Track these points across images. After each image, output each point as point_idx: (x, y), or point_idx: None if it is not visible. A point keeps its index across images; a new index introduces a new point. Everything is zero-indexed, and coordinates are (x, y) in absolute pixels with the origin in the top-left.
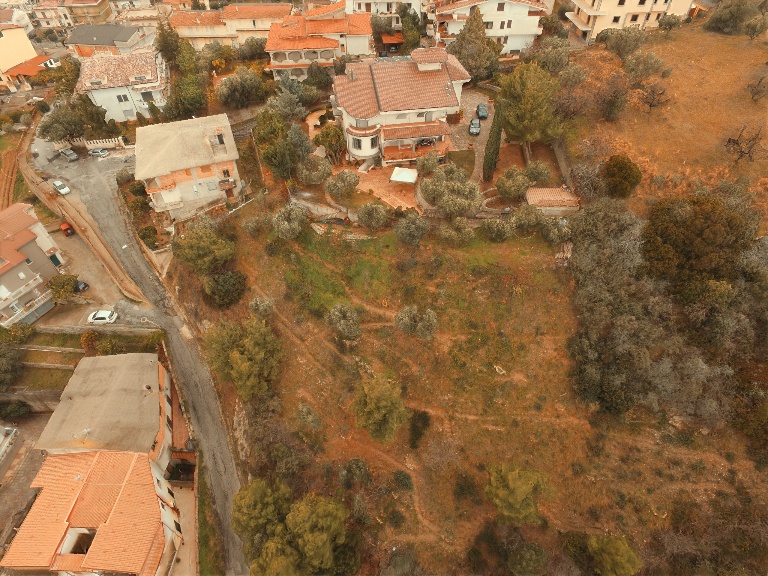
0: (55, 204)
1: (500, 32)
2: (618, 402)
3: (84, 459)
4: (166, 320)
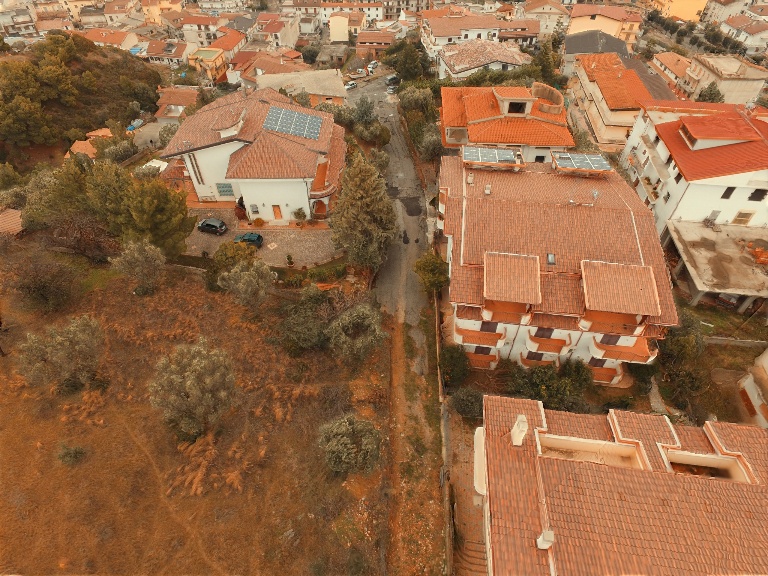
0: None
1: None
2: None
3: None
4: None
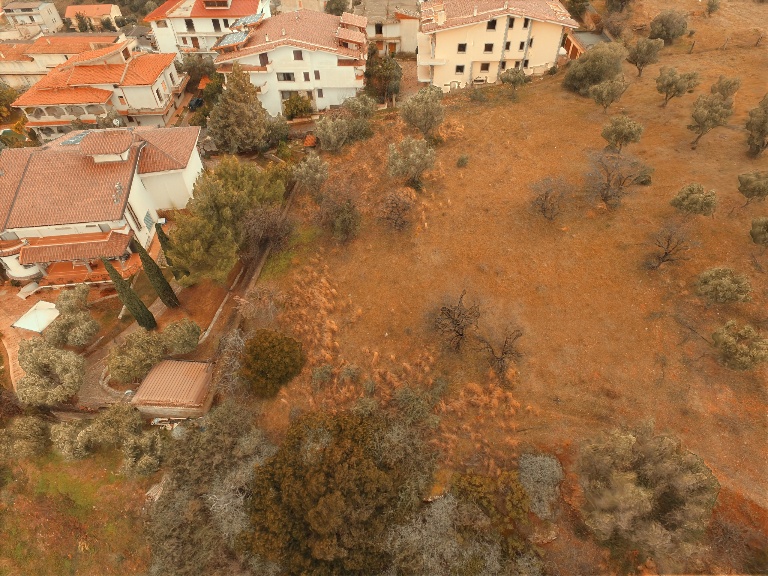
0: None
1: (306, 85)
2: None
3: None
4: None
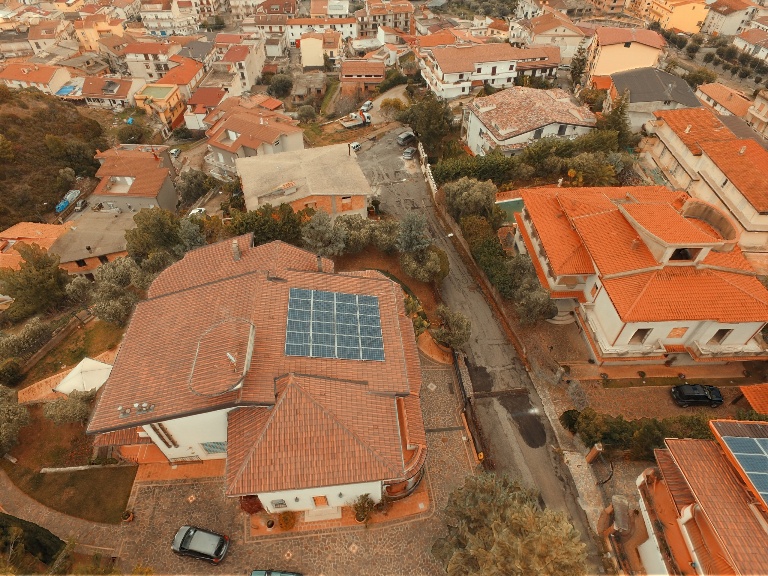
0: None
1: None
2: None
3: None
4: None
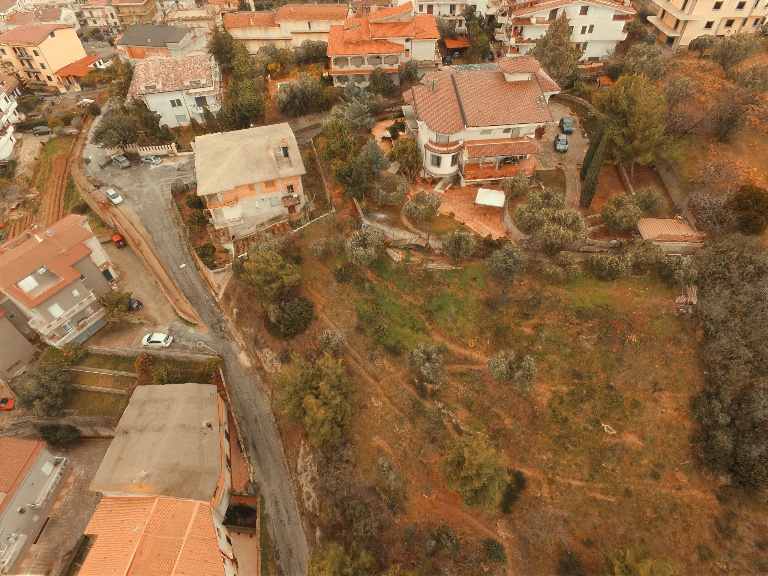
0: (108, 214)
1: (580, 38)
2: (759, 479)
3: (142, 505)
4: (223, 345)
